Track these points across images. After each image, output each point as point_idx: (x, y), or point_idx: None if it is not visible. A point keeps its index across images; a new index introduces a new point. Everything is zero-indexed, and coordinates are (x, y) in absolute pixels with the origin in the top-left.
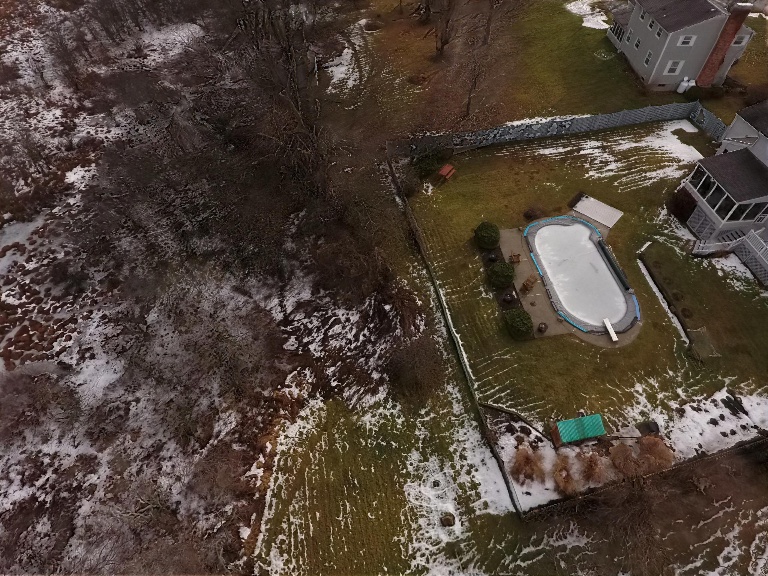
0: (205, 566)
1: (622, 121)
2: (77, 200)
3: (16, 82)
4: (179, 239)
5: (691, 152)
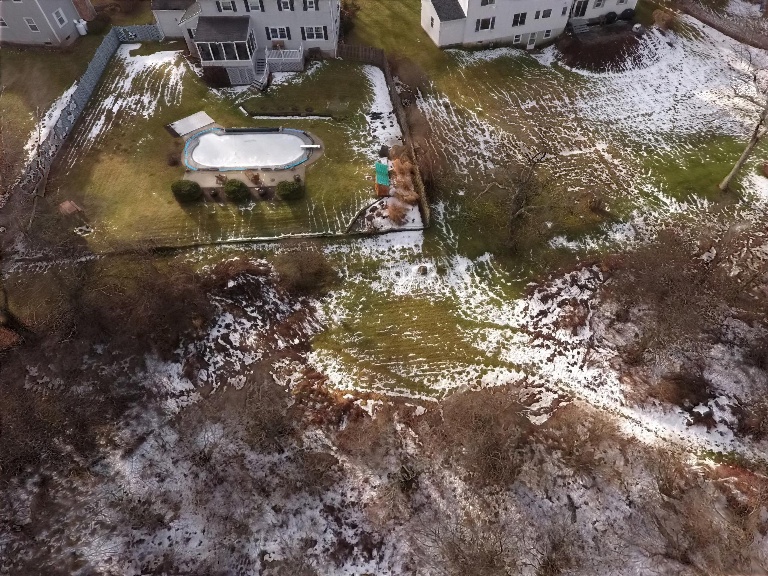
0: (444, 441)
1: (96, 74)
2: None
3: None
4: None
5: (164, 54)
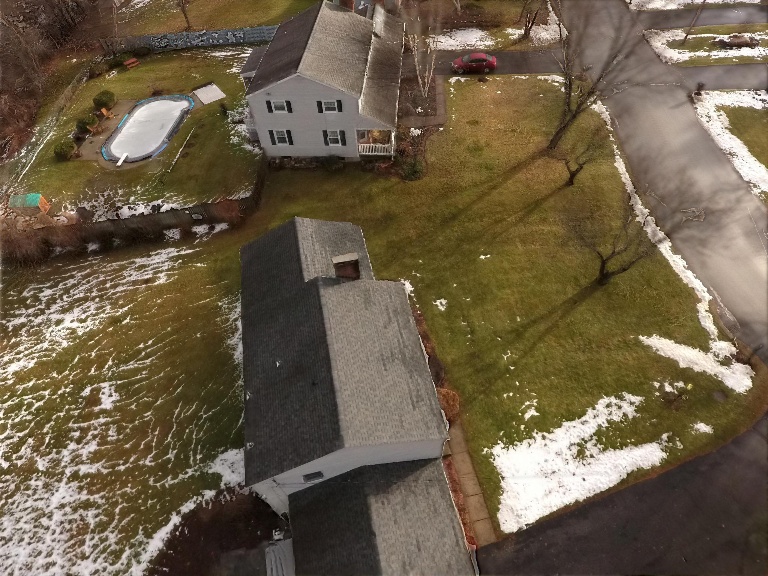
0: None
1: None
2: None
3: None
4: None
5: None
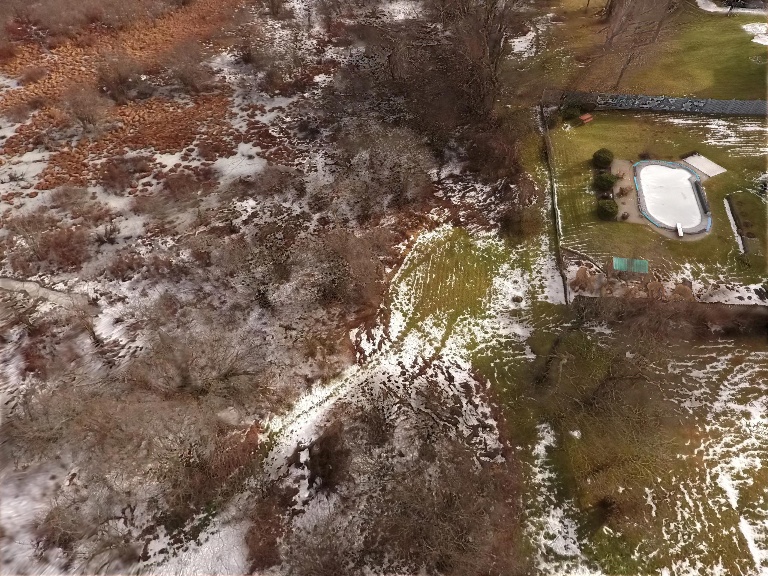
0: None
1: (755, 110)
2: (319, 92)
3: (291, 20)
4: (379, 125)
5: None
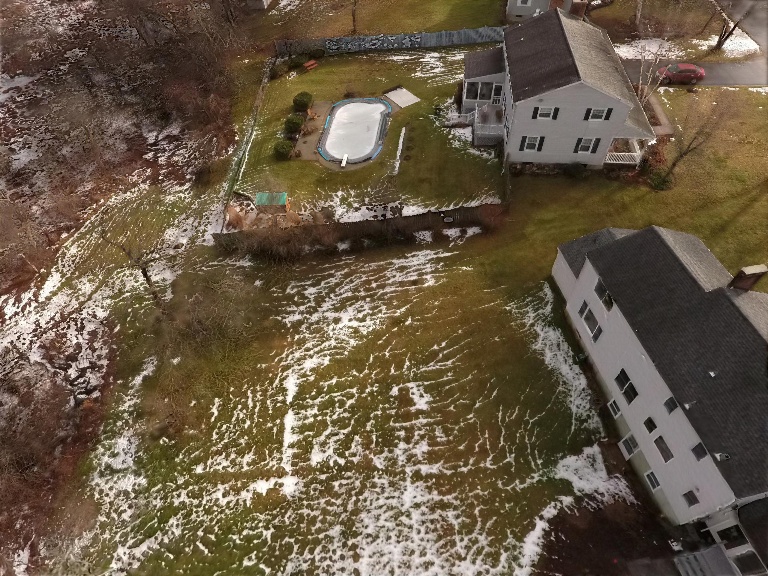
0: None
1: (465, 39)
2: (66, 67)
3: None
4: (116, 95)
5: None
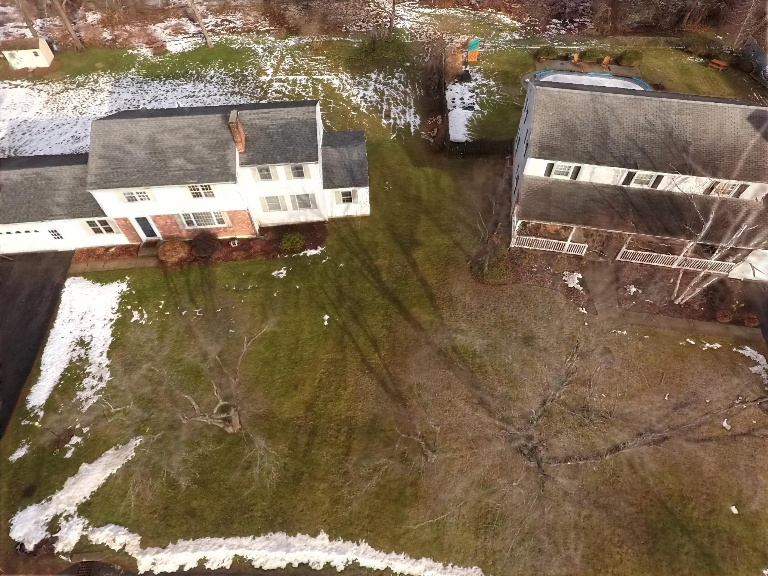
0: (458, 1)
1: None
2: None
3: None
4: None
5: None
